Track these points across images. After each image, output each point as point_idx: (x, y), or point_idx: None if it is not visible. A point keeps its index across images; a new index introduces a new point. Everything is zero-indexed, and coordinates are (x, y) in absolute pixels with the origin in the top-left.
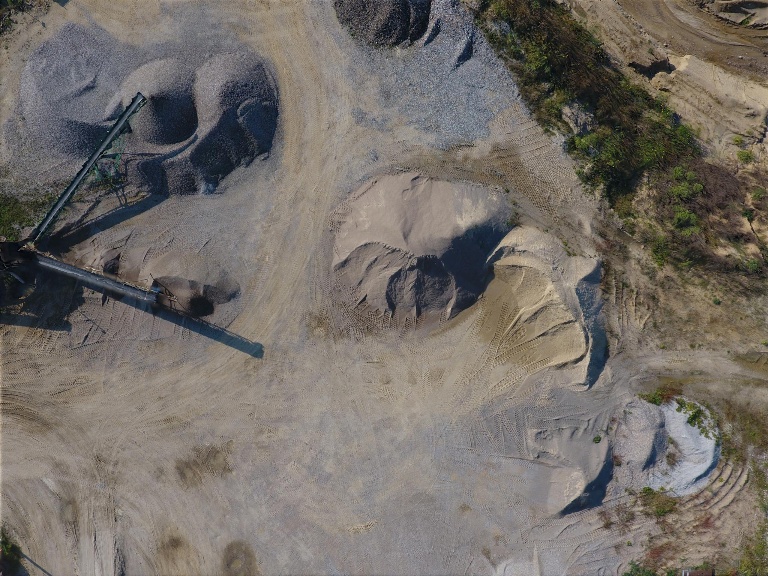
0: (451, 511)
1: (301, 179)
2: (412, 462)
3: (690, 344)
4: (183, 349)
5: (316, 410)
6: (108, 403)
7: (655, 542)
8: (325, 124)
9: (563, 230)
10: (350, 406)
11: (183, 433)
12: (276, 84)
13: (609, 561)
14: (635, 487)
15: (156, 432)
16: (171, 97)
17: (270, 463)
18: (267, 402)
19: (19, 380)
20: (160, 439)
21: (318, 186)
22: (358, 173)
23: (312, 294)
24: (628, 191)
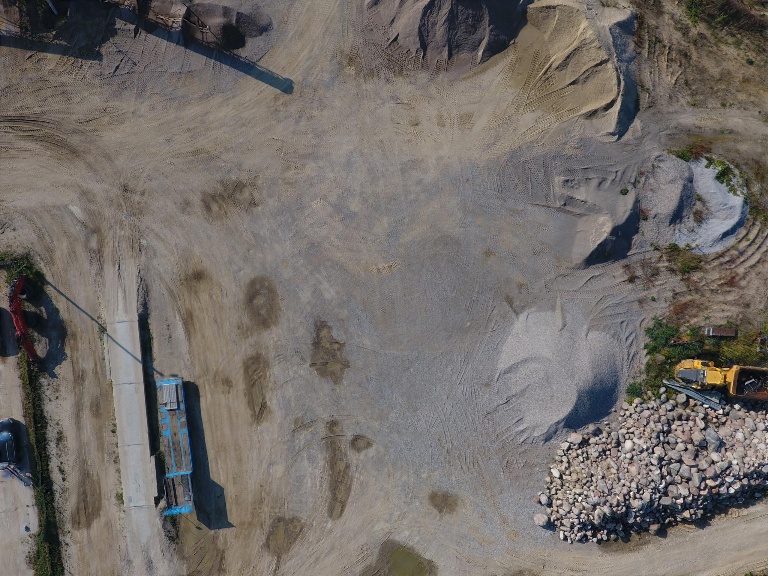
0: (475, 255)
1: None
2: (438, 204)
3: (721, 103)
4: (213, 82)
5: (344, 148)
6: (137, 133)
7: (679, 299)
8: None
9: None
10: (378, 146)
11: (210, 166)
12: None
13: (632, 315)
14: (661, 243)
15: (183, 163)
16: None
17: (296, 199)
18: (295, 138)
19: (49, 107)
20: (187, 171)
21: None
22: None
23: (344, 32)
24: None
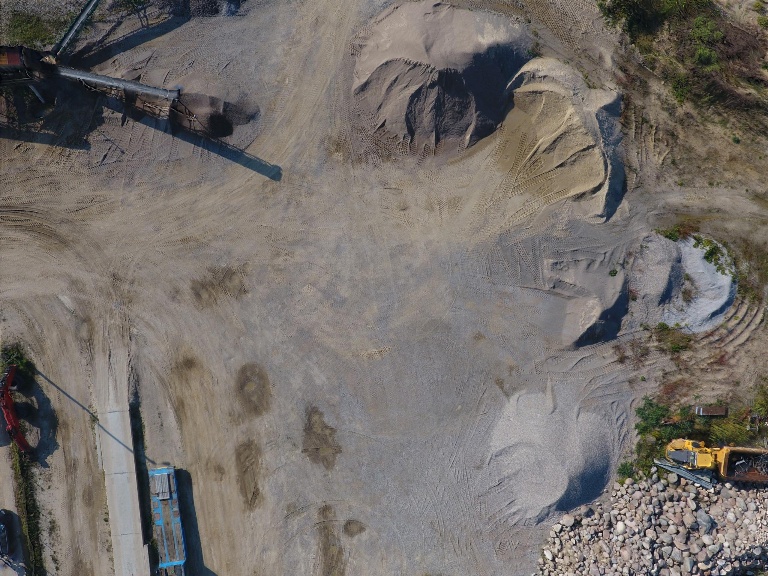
0: (465, 339)
1: (323, 3)
2: (427, 289)
3: (708, 182)
4: (201, 170)
5: (333, 234)
6: (125, 222)
7: (669, 378)
8: None
9: (584, 63)
10: (367, 231)
11: (199, 254)
12: None
13: (622, 395)
14: (650, 322)
15: (173, 252)
16: None
17: (286, 286)
18: (284, 225)
19: (37, 197)
20: (176, 259)
21: (340, 10)
22: None
23: (331, 118)
24: (649, 33)
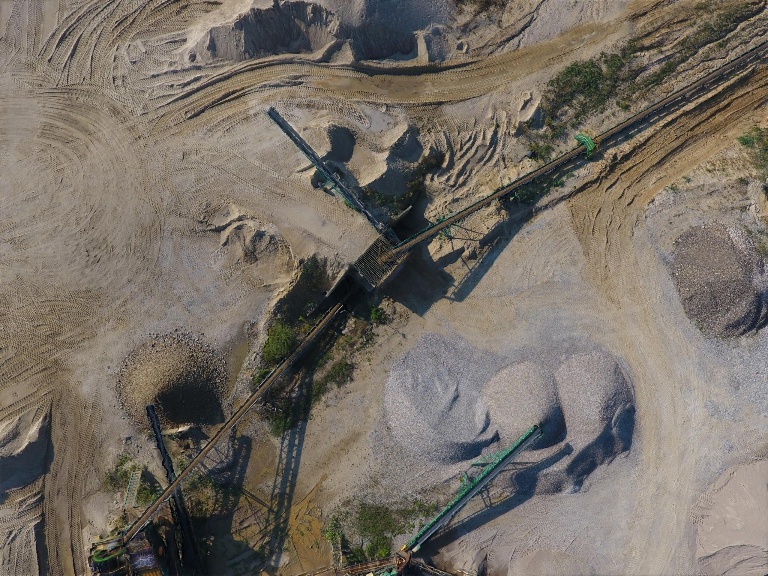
0: None
1: (662, 474)
2: None
3: None
4: None
5: None
6: None
7: None
8: (681, 418)
9: None
10: None
11: None
12: (632, 382)
13: None
14: None
15: None
16: (551, 415)
17: None
18: None
19: None
20: None
21: (678, 480)
22: (715, 465)
23: None
24: None
